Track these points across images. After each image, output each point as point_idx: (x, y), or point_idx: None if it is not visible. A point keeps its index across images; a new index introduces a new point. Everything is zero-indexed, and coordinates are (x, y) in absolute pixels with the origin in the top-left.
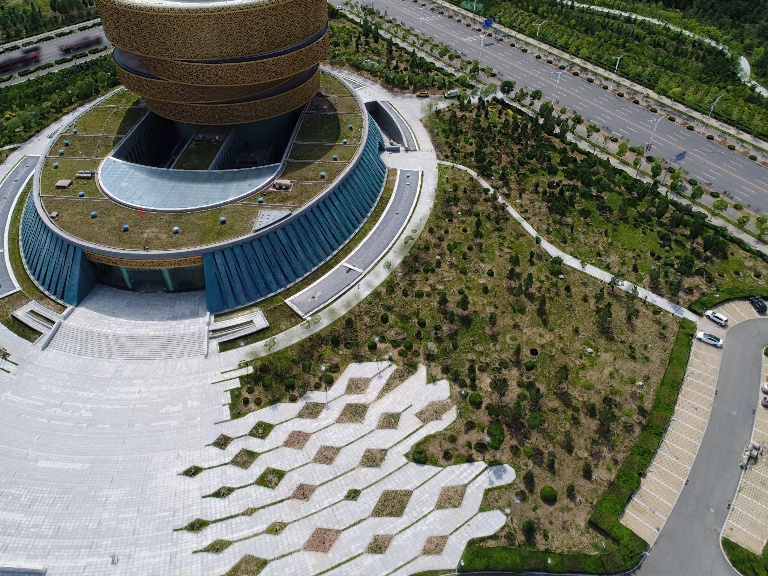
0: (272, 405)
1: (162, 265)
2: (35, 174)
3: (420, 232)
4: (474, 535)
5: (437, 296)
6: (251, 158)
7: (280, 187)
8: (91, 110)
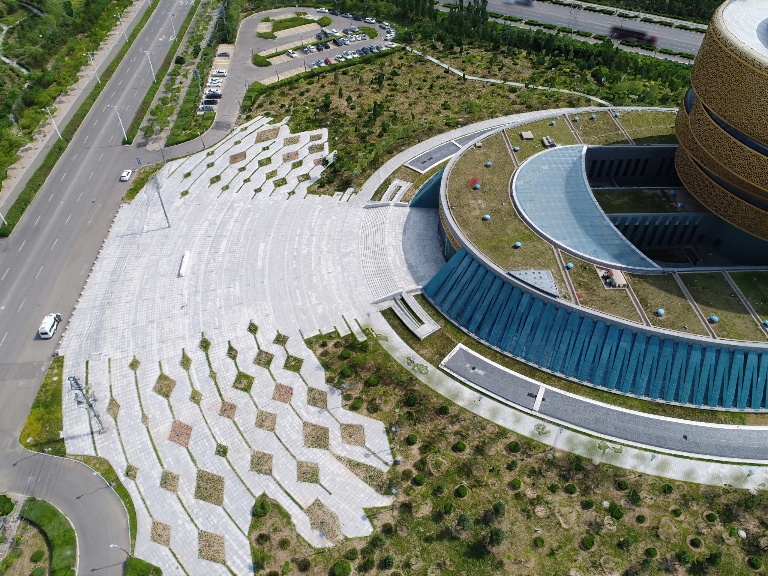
0: (322, 365)
1: (445, 228)
2: (533, 118)
3: (657, 474)
4: (165, 574)
5: (519, 508)
6: (701, 255)
7: (609, 278)
8: (666, 112)
